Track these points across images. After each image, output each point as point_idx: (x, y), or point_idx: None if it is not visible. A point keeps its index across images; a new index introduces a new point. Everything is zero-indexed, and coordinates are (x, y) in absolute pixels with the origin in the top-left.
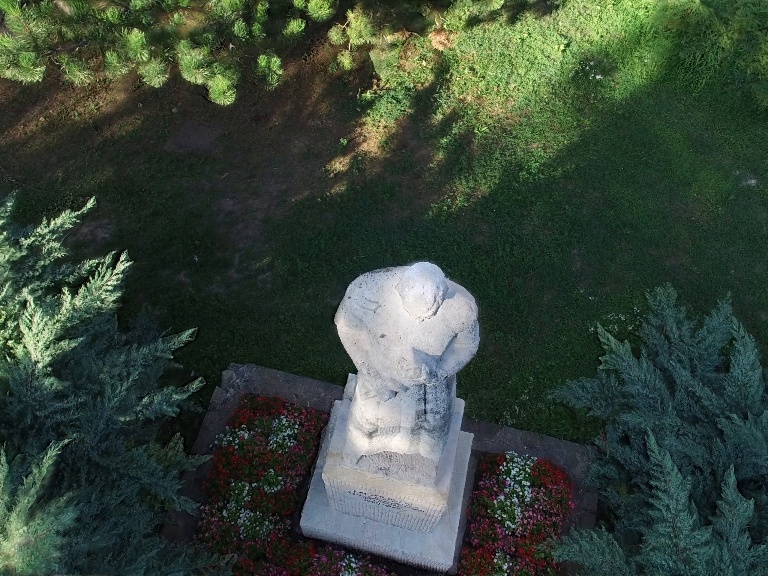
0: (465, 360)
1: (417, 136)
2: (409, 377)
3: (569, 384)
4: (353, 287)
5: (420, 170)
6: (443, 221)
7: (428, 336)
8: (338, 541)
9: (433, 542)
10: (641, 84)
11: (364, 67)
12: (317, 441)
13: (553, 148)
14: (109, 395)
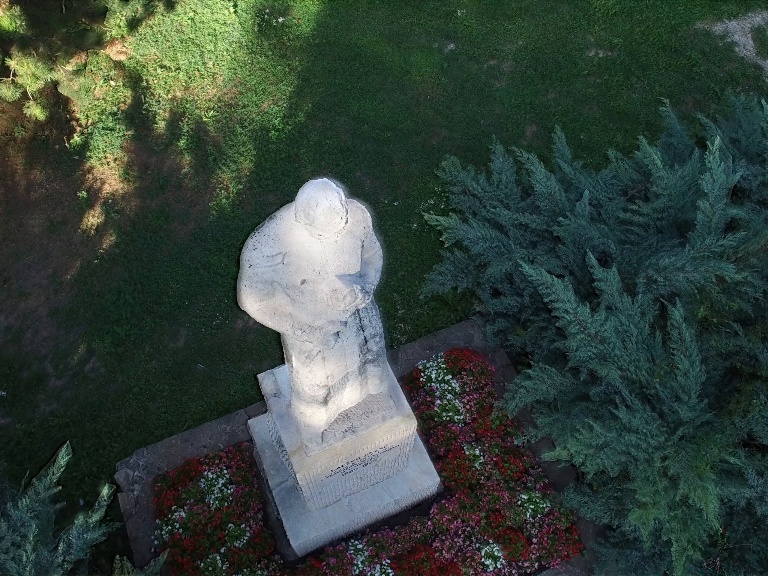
0: (379, 264)
1: (153, 152)
2: (348, 304)
3: (429, 277)
4: (248, 253)
5: (177, 180)
6: (230, 213)
7: (342, 256)
8: (333, 537)
9: (414, 473)
10: (318, 10)
11: (53, 115)
12: (253, 470)
13: (283, 99)
14: (17, 570)
